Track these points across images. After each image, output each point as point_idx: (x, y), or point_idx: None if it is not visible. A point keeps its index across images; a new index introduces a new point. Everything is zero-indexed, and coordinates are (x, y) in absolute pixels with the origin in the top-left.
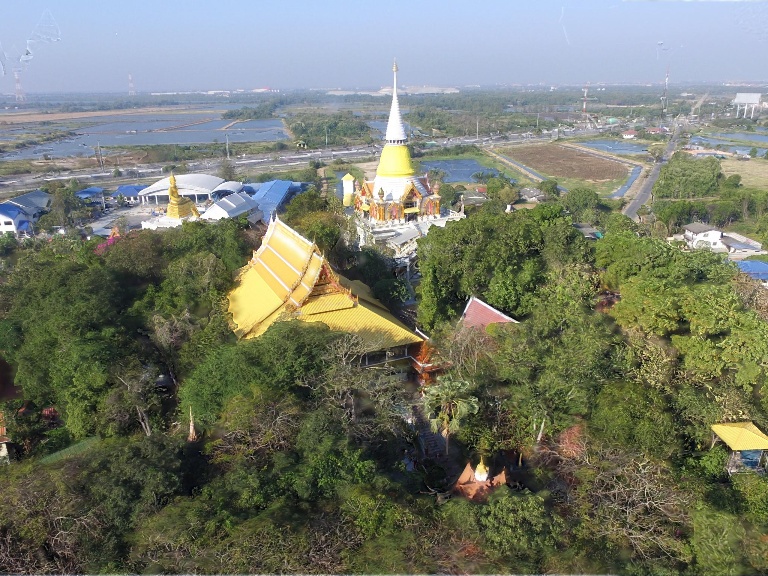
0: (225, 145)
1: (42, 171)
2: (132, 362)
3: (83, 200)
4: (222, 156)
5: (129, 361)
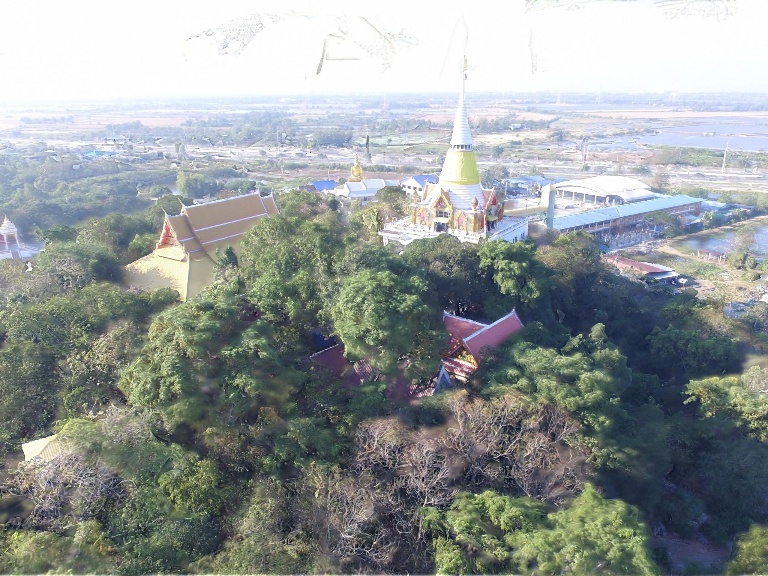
0: (744, 155)
1: (549, 159)
2: (55, 243)
3: (509, 184)
4: (735, 167)
5: (56, 242)
